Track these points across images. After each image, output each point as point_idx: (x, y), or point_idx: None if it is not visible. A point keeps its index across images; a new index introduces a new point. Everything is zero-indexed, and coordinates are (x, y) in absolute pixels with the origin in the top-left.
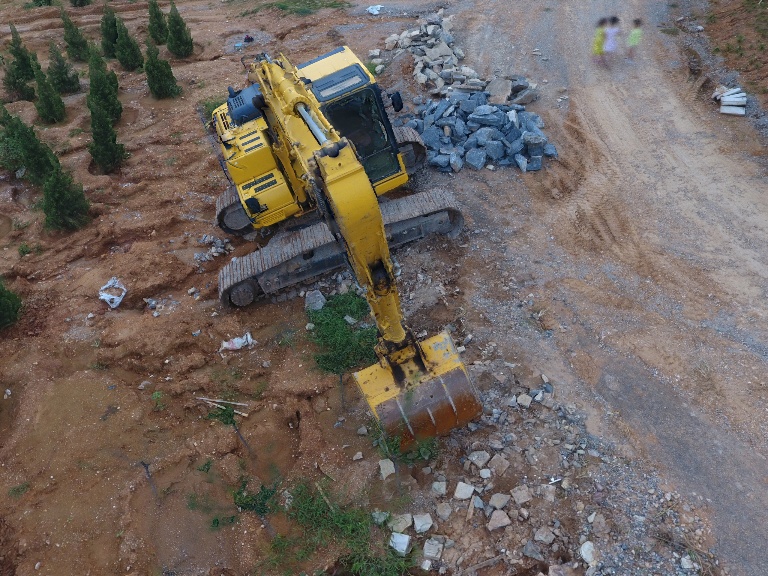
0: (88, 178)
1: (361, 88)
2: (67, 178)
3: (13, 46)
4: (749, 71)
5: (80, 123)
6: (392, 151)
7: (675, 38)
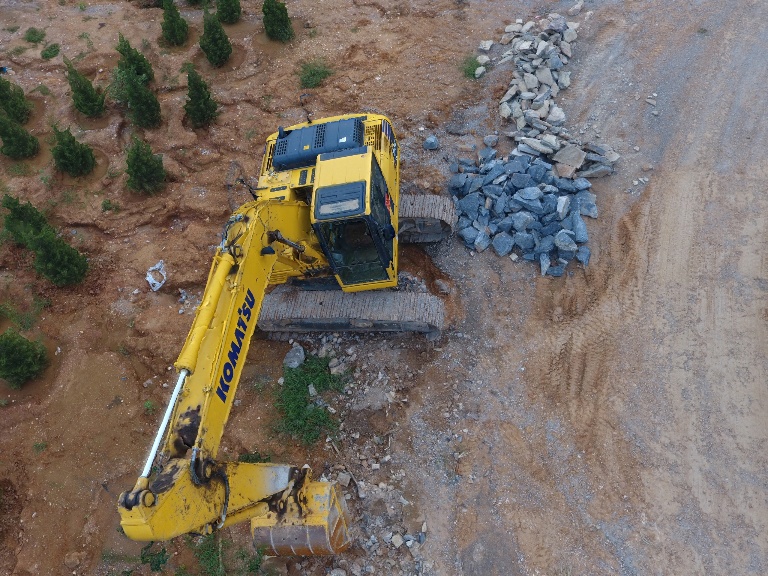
0: (178, 133)
1: (355, 216)
2: (147, 153)
3: None
4: None
5: (194, 55)
6: (381, 265)
7: None
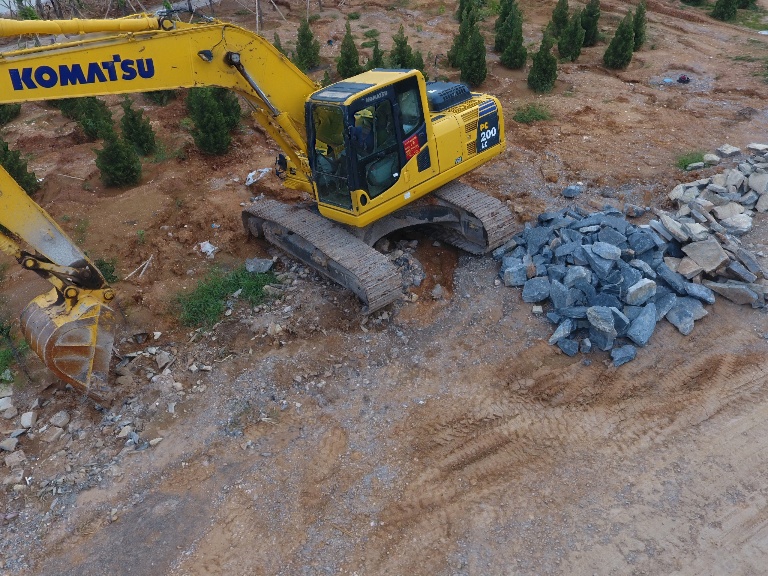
0: None
1: (336, 104)
2: None
3: (508, 1)
4: None
5: (456, 74)
6: None
7: None
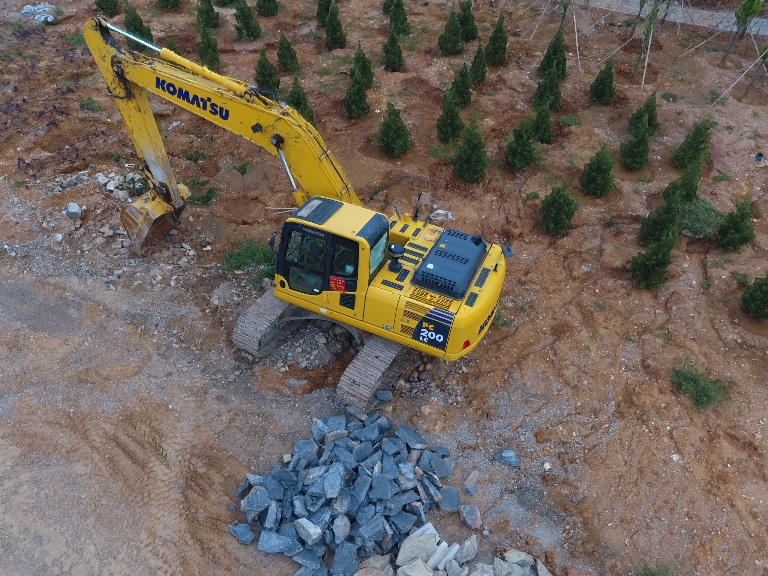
0: (619, 252)
1: None
2: (558, 201)
3: None
4: None
5: None
6: None
7: None
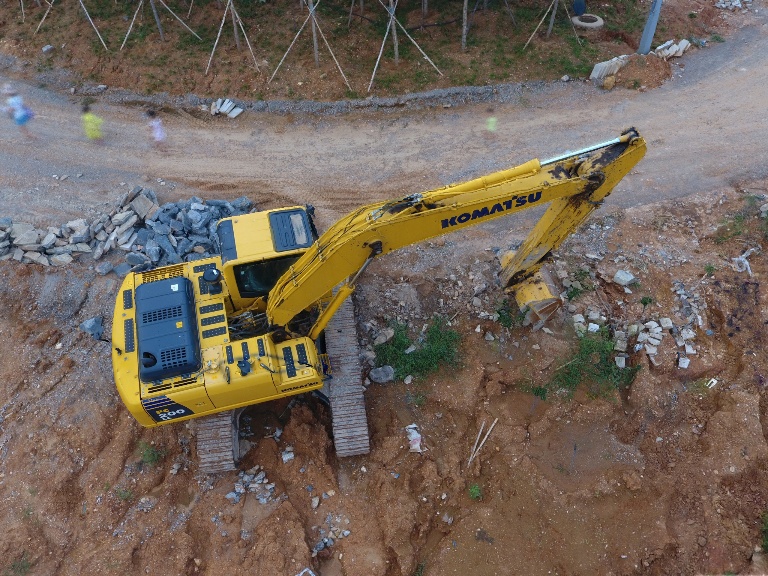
0: None
1: None
2: None
3: None
4: (194, 89)
5: None
6: None
7: (102, 103)
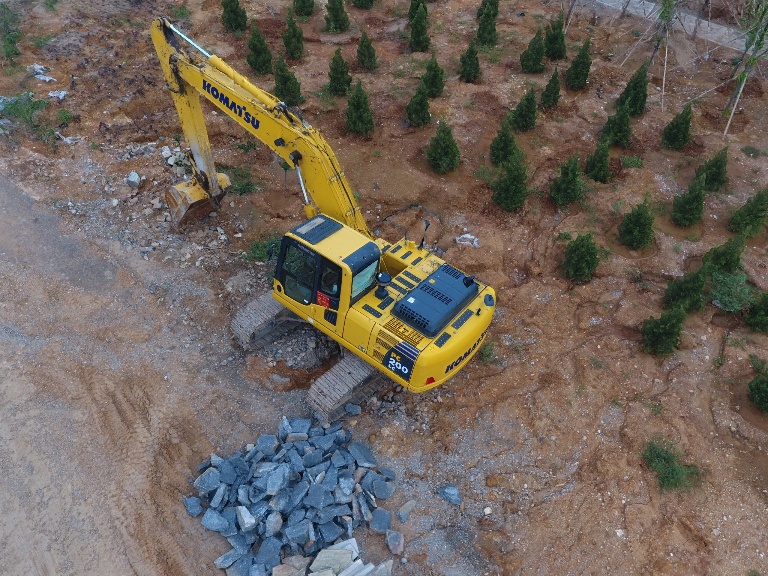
0: (636, 311)
1: None
2: None
3: None
4: None
5: None
6: None
7: None
